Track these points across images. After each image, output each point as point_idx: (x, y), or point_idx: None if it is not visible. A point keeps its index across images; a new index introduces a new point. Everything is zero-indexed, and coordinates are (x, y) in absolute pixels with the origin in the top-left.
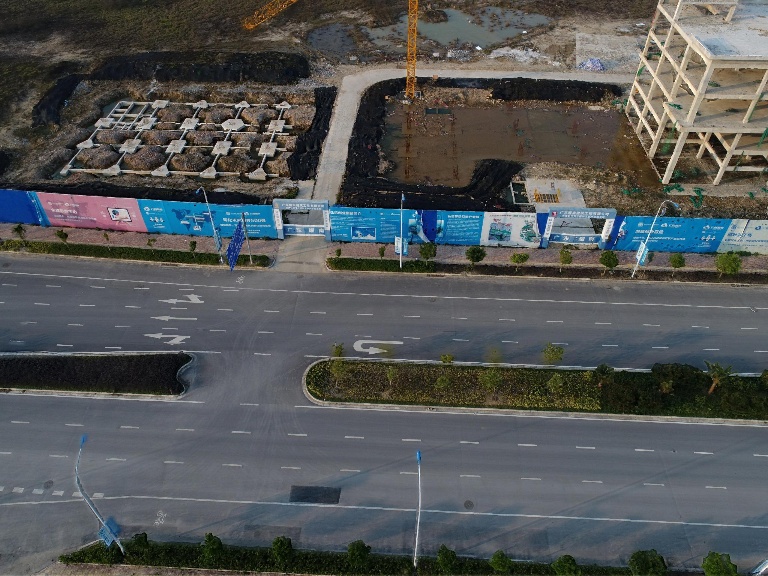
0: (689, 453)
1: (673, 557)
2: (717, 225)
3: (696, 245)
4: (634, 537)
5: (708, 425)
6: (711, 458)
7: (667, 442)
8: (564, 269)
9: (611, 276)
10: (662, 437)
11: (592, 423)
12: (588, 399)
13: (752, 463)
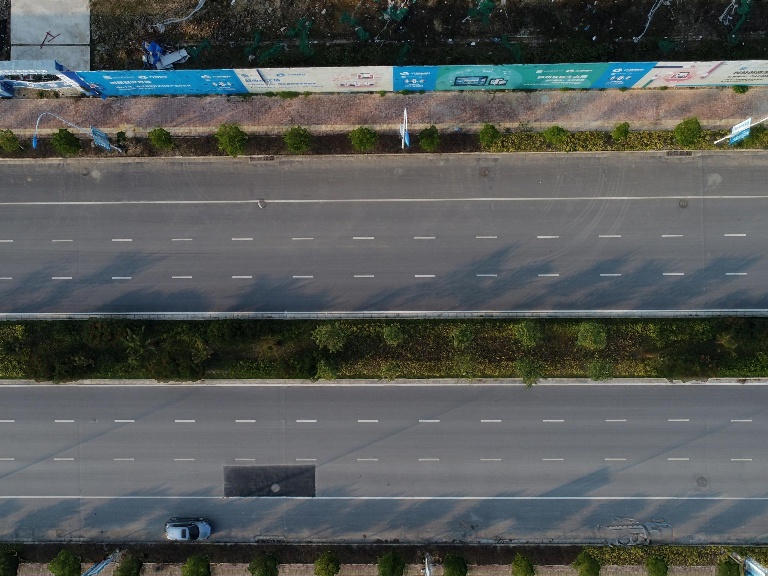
0: (109, 422)
1: (62, 529)
2: (218, 74)
3: (214, 89)
4: (32, 512)
5: (140, 387)
6: (130, 427)
7: (90, 410)
8: (30, 141)
9: (92, 151)
10: (87, 404)
11: (17, 391)
12: (12, 365)
13: (169, 431)
